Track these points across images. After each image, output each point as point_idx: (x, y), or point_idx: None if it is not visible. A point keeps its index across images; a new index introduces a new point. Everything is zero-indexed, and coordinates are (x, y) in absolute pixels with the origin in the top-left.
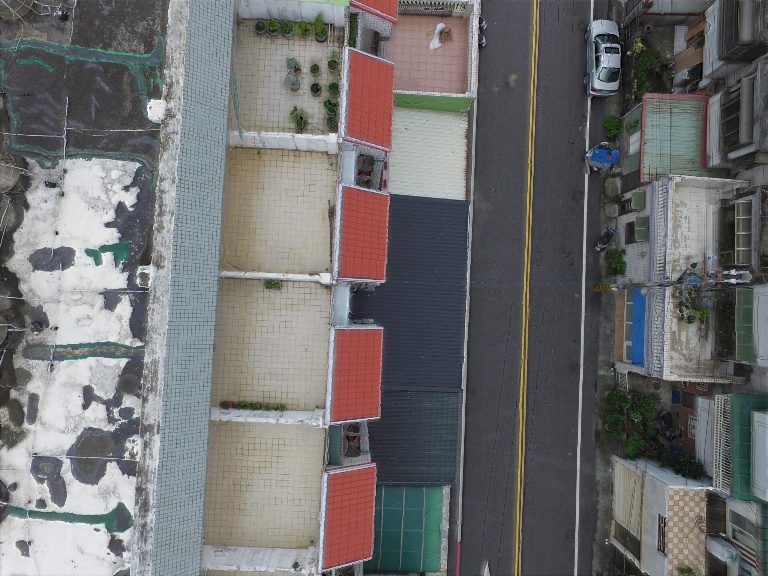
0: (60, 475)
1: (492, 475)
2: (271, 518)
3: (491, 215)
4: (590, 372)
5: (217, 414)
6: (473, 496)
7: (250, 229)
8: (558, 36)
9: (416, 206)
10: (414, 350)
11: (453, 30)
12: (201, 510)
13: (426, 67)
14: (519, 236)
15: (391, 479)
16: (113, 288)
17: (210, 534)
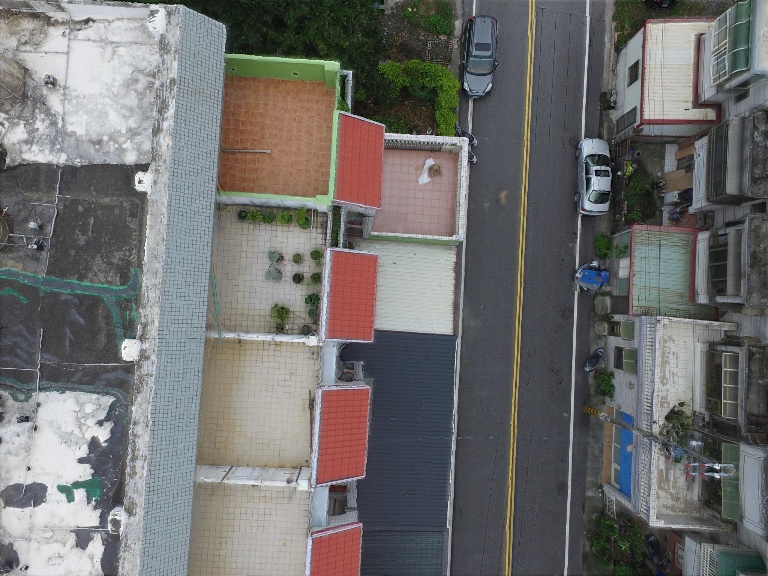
0: None
1: None
2: None
3: (480, 332)
4: (578, 493)
5: None
6: None
7: (230, 420)
8: (549, 152)
9: (403, 342)
10: (399, 488)
11: (442, 165)
12: None
13: (414, 202)
14: (508, 354)
15: None
16: (85, 526)
17: None
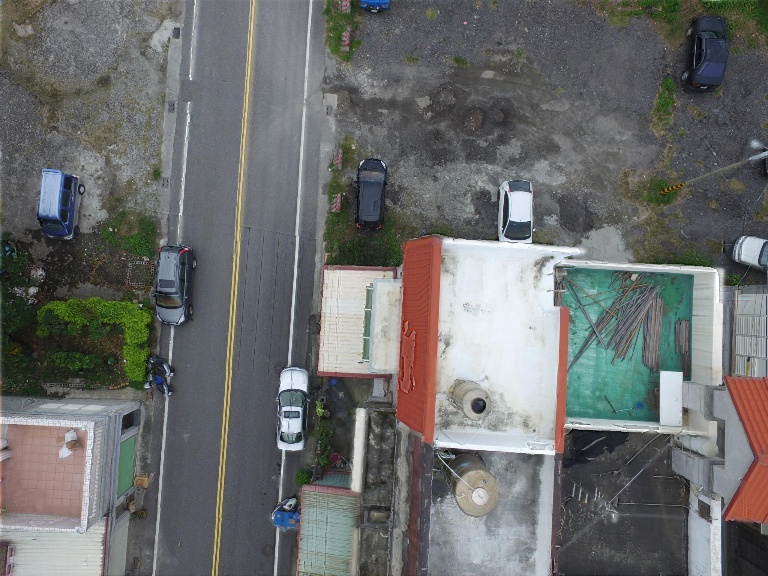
0: None
1: None
2: None
3: (176, 571)
4: None
5: None
6: None
7: None
8: (253, 380)
9: None
10: None
11: (85, 436)
12: None
13: (54, 477)
14: None
15: None
16: None
17: None
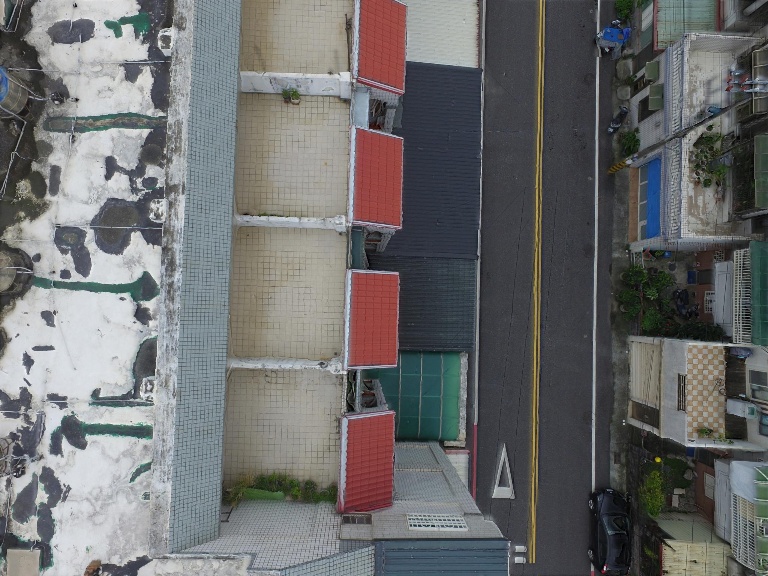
0: (84, 245)
1: (508, 358)
2: (294, 331)
3: (502, 100)
4: (604, 255)
5: (238, 216)
6: (489, 379)
7: (267, 43)
8: None
9: (429, 73)
10: (429, 217)
11: None
12: (227, 284)
13: None
14: (531, 120)
15: (408, 344)
16: (133, 60)
17: (233, 346)
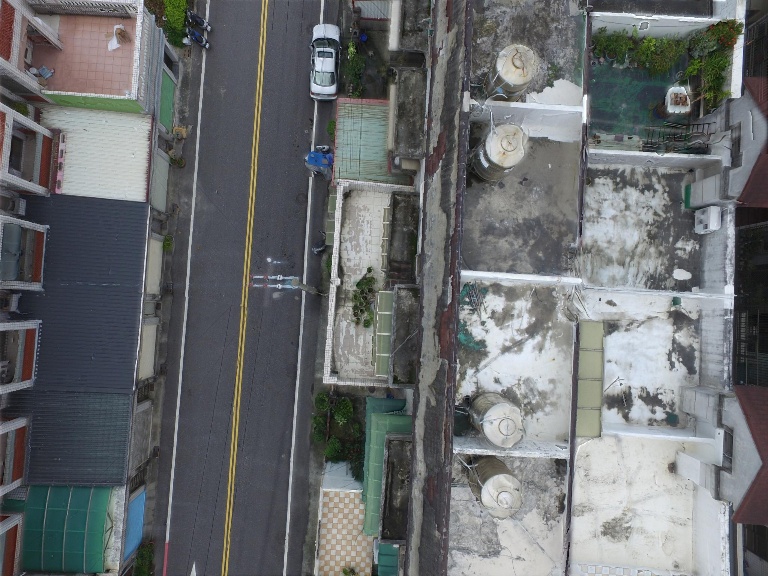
0: None
1: (204, 476)
2: None
3: (213, 217)
4: (307, 374)
5: None
6: (184, 497)
7: None
8: (286, 39)
9: (92, 207)
10: (84, 351)
11: (133, 32)
12: None
13: (104, 68)
14: (240, 238)
15: (54, 480)
16: None
17: None
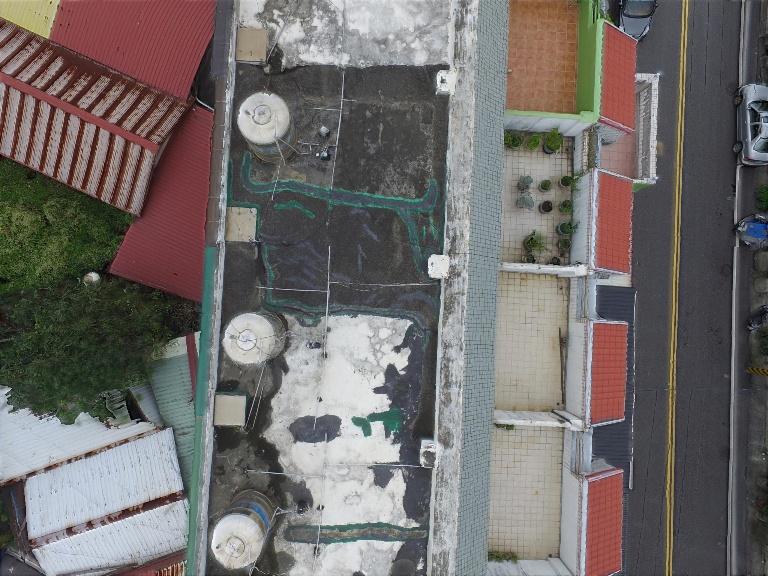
0: None
1: (638, 566)
2: None
3: None
4: (740, 457)
5: None
6: None
7: None
8: (705, 101)
9: None
10: None
11: None
12: None
13: None
14: (665, 313)
15: None
16: (383, 461)
17: None
